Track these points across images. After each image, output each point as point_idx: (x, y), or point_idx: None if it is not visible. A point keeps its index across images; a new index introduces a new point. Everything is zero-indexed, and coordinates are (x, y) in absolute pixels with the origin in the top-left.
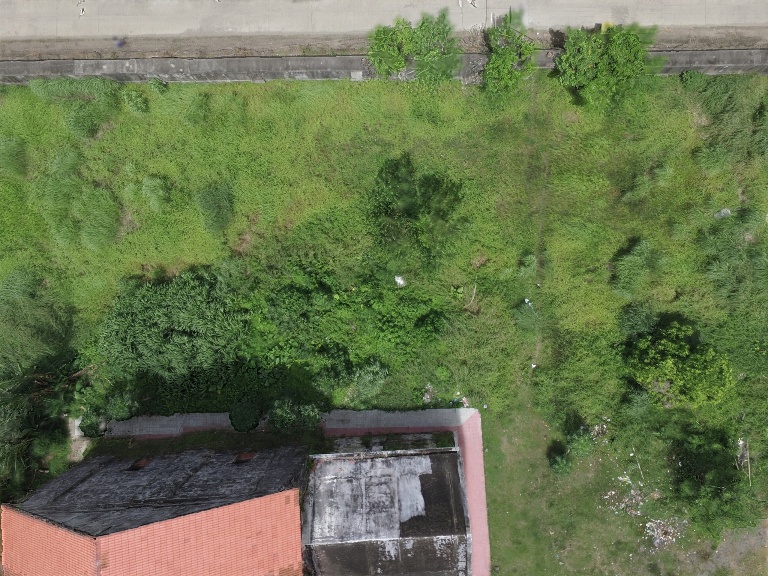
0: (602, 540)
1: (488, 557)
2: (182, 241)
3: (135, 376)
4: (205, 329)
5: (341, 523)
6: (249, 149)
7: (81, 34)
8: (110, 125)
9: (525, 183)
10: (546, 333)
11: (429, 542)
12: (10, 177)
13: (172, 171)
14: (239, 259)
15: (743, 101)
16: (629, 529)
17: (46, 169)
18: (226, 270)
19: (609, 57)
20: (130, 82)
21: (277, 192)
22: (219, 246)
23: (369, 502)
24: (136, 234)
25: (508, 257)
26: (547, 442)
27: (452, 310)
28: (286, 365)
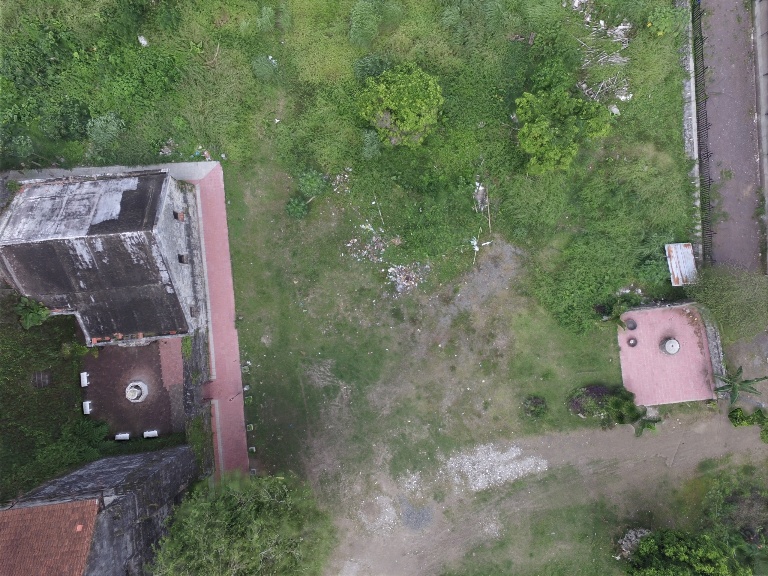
0: (345, 287)
1: (232, 307)
2: None
3: None
4: None
5: (32, 228)
6: None
7: None
8: None
9: None
10: (289, 88)
11: (118, 241)
12: None
13: None
14: None
15: None
16: (372, 276)
17: None
18: None
19: None
20: None
21: None
22: None
23: (66, 212)
24: None
25: (250, 14)
26: (290, 193)
27: (192, 64)
28: (26, 123)
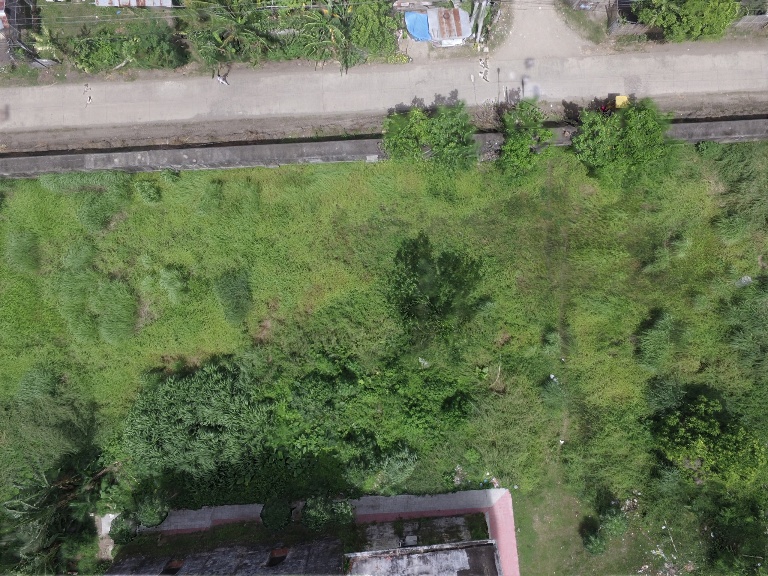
0: None
1: None
2: (202, 331)
3: (161, 472)
4: (231, 424)
5: None
6: (266, 235)
7: (89, 123)
8: (123, 215)
9: (545, 257)
10: (573, 408)
11: None
12: (23, 272)
13: (188, 260)
14: (261, 348)
15: (759, 167)
16: None
17: (60, 263)
18: (248, 360)
19: (629, 141)
20: (142, 172)
21: (296, 278)
22: (240, 335)
23: None
24: (155, 326)
25: (532, 334)
26: (579, 519)
27: (478, 390)
28: (313, 453)
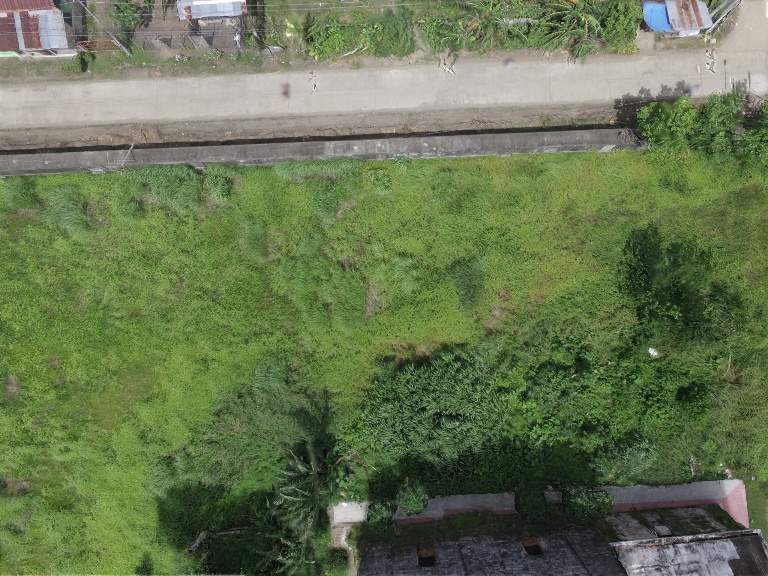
0: None
1: None
2: (434, 320)
3: (398, 461)
4: (474, 413)
5: None
6: (496, 224)
7: (314, 110)
8: (350, 203)
9: None
10: None
11: None
12: (250, 260)
13: (418, 249)
14: (496, 338)
15: None
16: None
17: (289, 251)
18: (485, 350)
19: None
20: (373, 160)
21: (529, 267)
22: (473, 324)
23: None
24: (385, 314)
25: (762, 325)
26: None
27: (712, 381)
28: (548, 443)
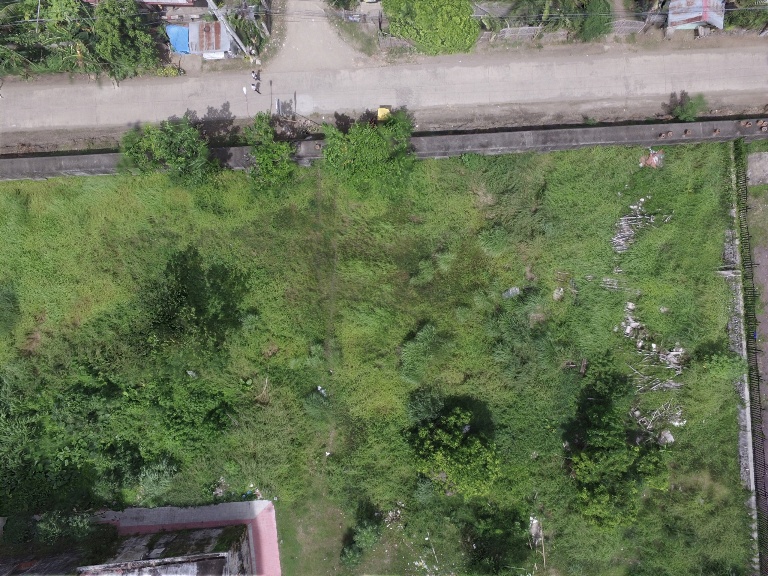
0: None
1: None
2: None
3: None
4: None
5: None
6: (34, 247)
7: None
8: None
9: (315, 269)
10: (339, 420)
11: None
12: None
13: None
14: (24, 361)
15: (526, 179)
16: None
17: None
18: (11, 373)
19: (360, 155)
20: None
21: (63, 290)
22: (6, 348)
23: None
24: None
25: (298, 345)
26: (342, 530)
27: (241, 402)
28: (77, 465)
